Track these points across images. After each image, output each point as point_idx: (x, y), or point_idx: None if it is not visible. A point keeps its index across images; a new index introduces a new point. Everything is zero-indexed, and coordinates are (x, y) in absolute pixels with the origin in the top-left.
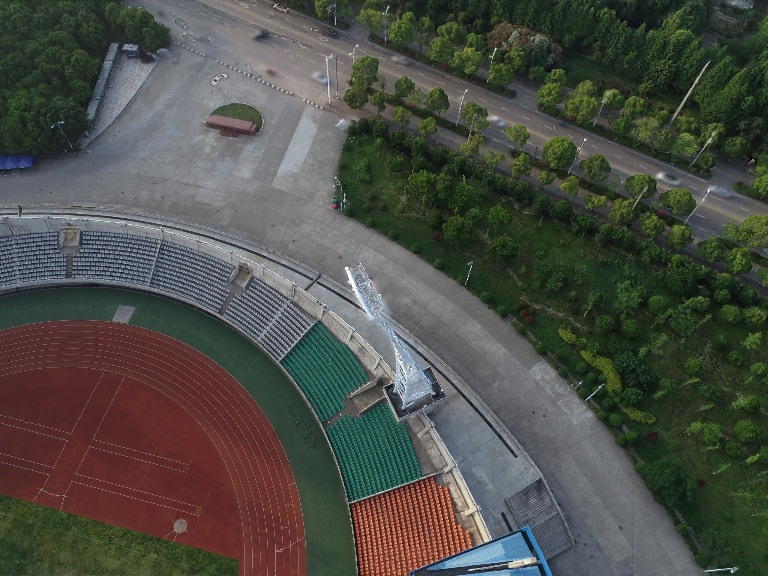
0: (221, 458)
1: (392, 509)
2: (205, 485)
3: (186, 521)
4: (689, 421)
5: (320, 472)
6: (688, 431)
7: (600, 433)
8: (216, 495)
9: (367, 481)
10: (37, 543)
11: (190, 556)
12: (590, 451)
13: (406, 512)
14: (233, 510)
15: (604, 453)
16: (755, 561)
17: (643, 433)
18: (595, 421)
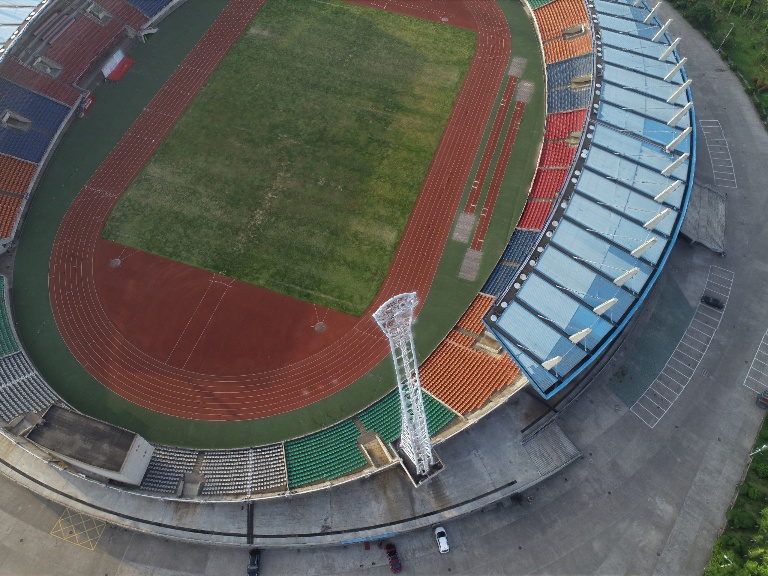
0: (461, 0)
1: (557, 7)
2: (455, 8)
3: (448, 18)
4: (715, 2)
5: (514, 8)
6: (714, 1)
7: (664, 5)
8: (461, 11)
9: (542, 1)
10: (376, 19)
11: (452, 28)
12: (659, 10)
13: (564, 6)
14: (471, 17)
15: (666, 11)
16: (745, 49)
17: (689, 5)
18: (662, 1)
